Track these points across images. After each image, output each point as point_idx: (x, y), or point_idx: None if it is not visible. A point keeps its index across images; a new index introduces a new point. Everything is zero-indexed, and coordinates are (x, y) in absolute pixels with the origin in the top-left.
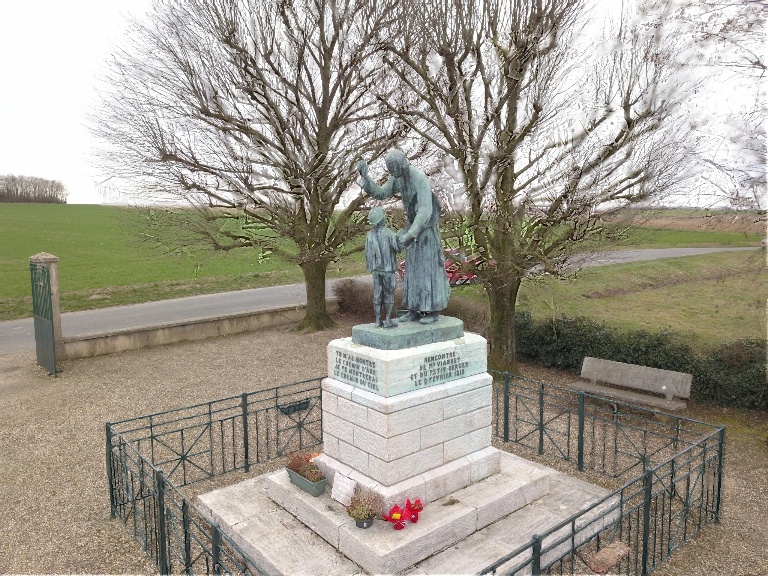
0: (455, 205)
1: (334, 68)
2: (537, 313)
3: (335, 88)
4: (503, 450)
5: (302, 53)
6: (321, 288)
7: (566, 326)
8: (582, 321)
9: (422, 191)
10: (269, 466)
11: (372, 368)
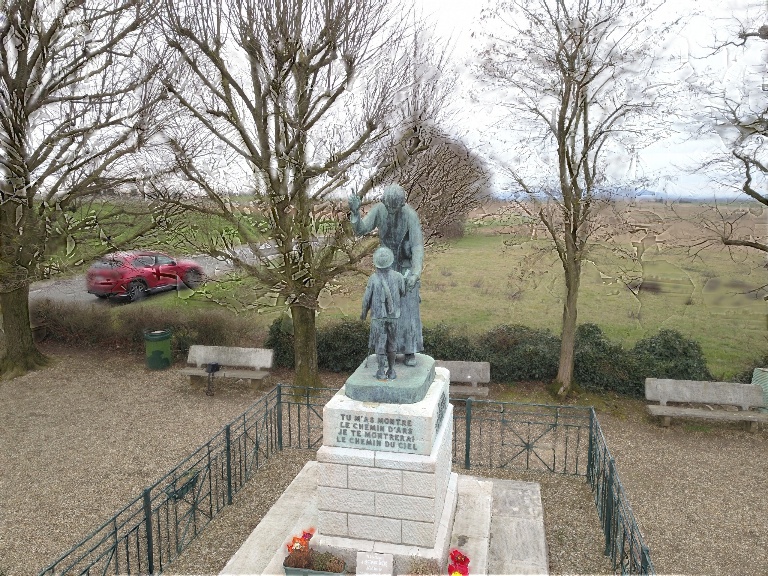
0: (279, 220)
1: (34, 30)
2: (321, 321)
3: (35, 56)
4: None
5: (17, 8)
6: (26, 315)
7: (351, 330)
8: (367, 324)
9: (417, 229)
10: (175, 571)
11: (407, 427)
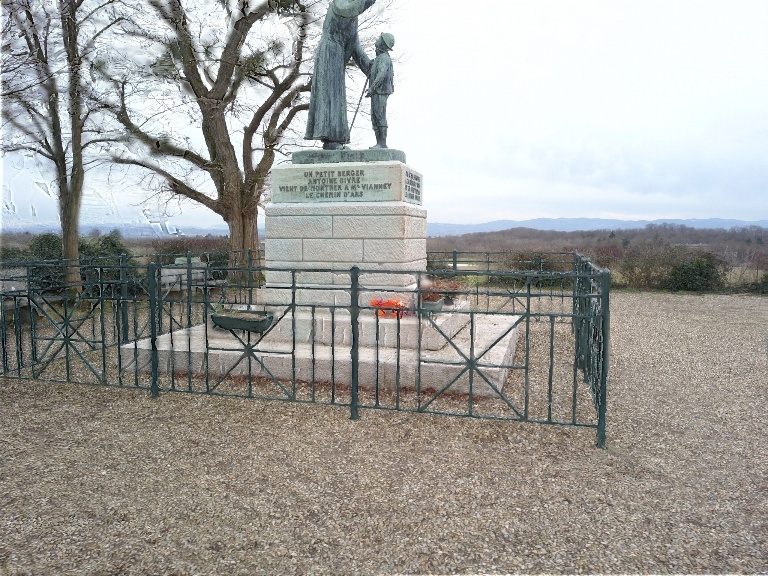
0: None
1: None
2: None
3: None
4: None
5: None
6: None
7: None
8: None
9: None
10: (322, 408)
11: None
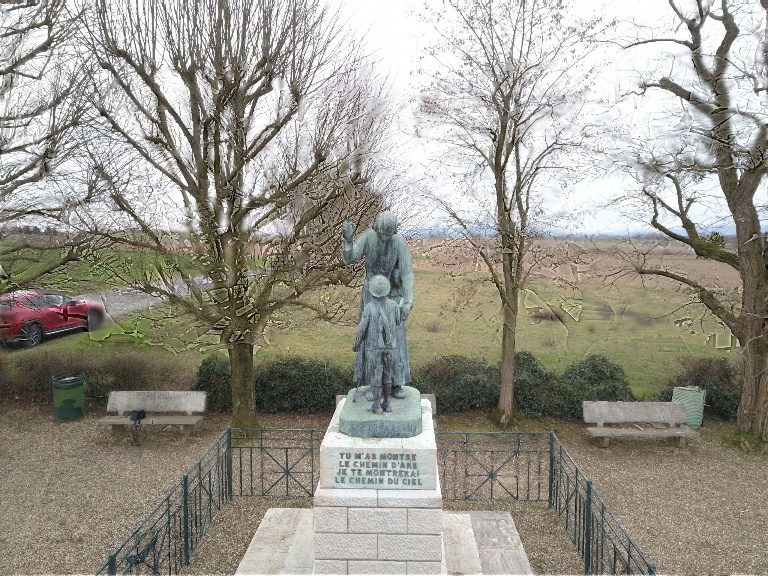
0: (223, 252)
1: None
2: None
3: None
4: None
5: None
6: None
7: (288, 368)
8: (304, 361)
9: (407, 257)
10: None
11: (411, 461)
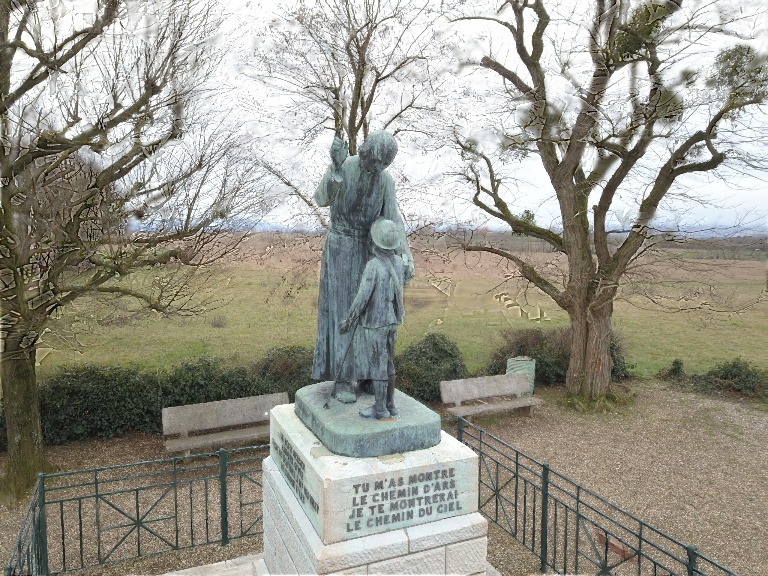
0: (5, 215)
1: None
2: None
3: None
4: (244, 554)
5: None
6: None
7: (79, 381)
8: (103, 369)
9: None
10: None
11: (448, 479)
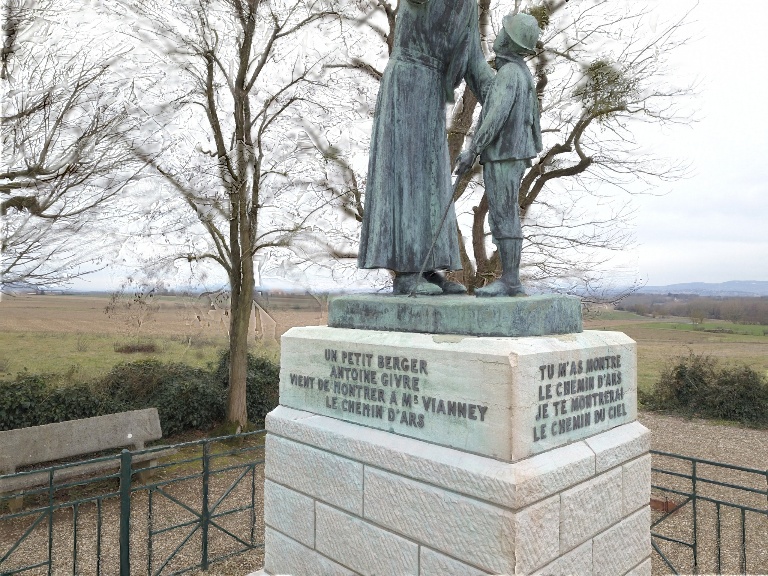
0: None
1: None
2: None
3: None
4: None
5: None
6: None
7: None
8: None
9: None
10: None
11: (617, 370)
